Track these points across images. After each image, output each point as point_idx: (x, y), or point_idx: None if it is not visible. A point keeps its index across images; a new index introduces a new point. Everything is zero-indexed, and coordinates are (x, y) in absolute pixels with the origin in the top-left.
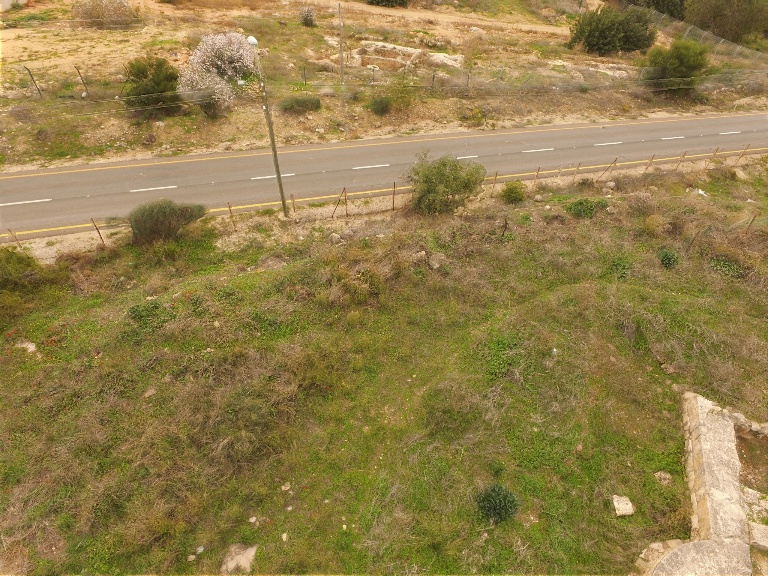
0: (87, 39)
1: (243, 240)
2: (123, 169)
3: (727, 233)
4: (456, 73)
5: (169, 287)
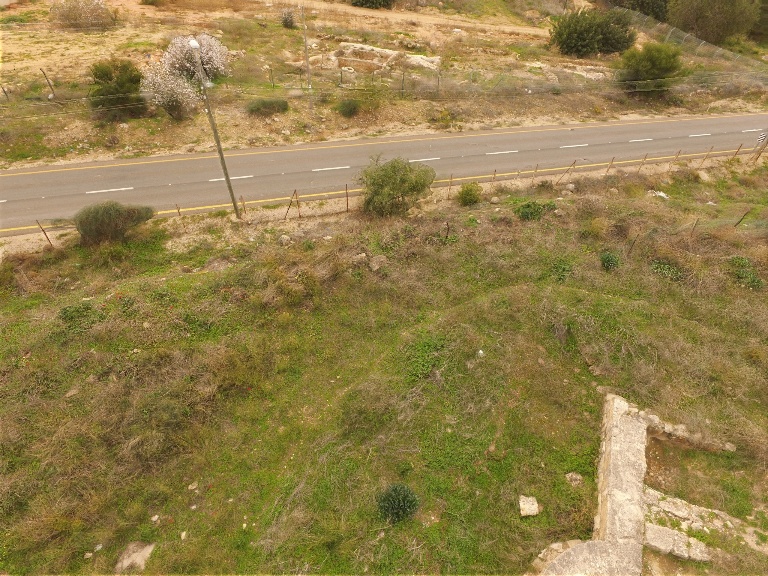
0: (62, 41)
1: (193, 241)
2: None
3: (673, 236)
4: (426, 75)
5: (110, 288)
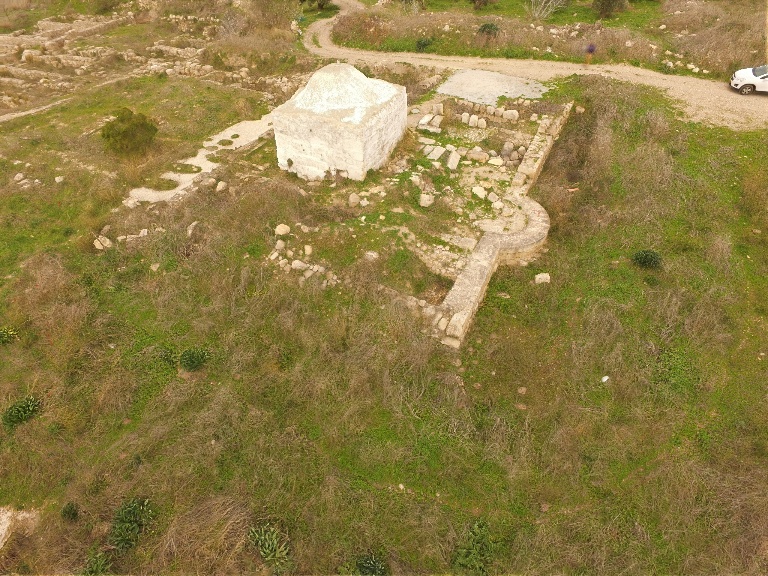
0: None
1: None
2: None
3: None
4: None
5: None
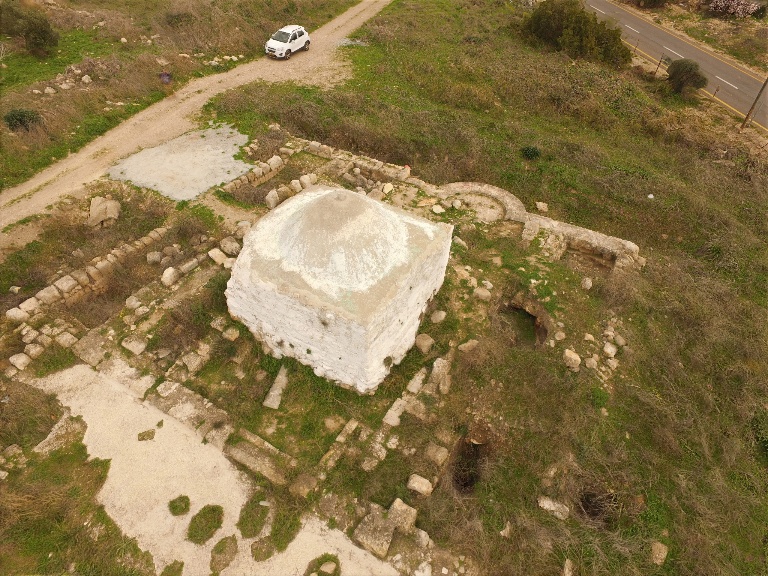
0: None
1: None
2: (739, 71)
3: None
4: None
5: None
